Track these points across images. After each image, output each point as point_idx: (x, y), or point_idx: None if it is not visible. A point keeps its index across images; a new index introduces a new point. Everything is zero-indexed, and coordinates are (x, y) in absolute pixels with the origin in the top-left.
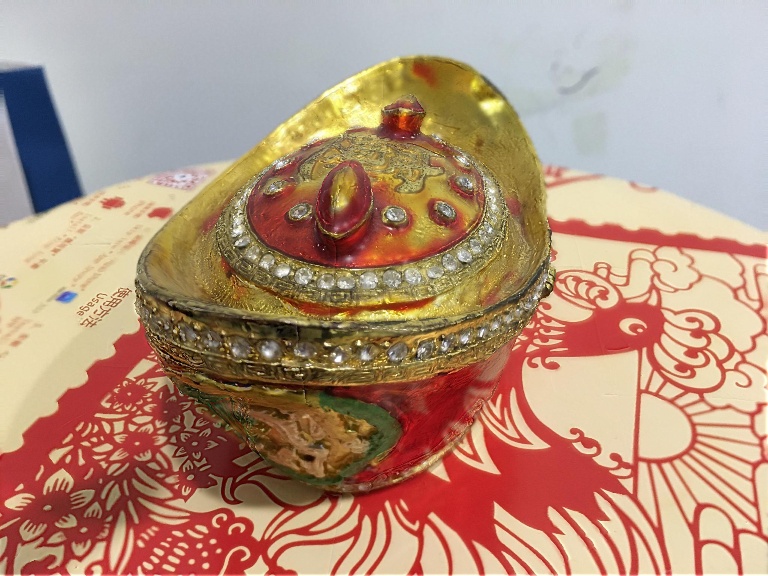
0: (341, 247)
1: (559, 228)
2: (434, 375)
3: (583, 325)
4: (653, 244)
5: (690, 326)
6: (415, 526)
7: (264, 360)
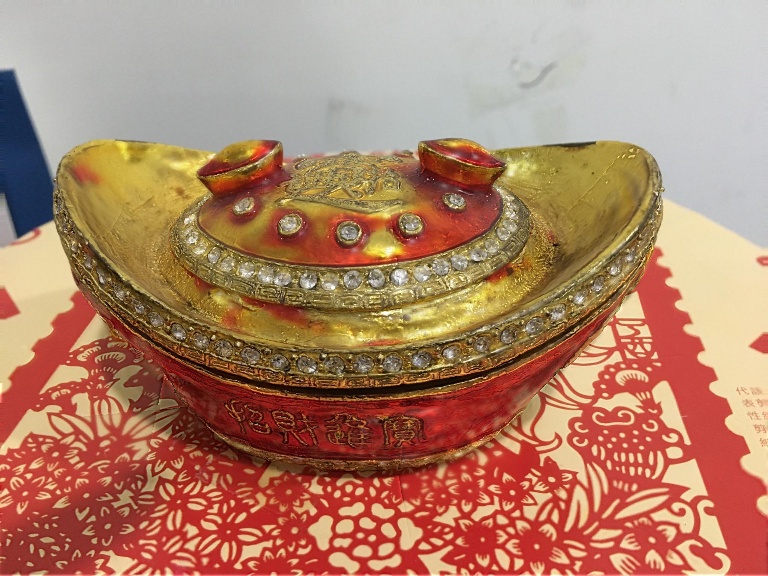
0: None
1: None
2: None
3: None
4: None
5: None
6: None
7: None
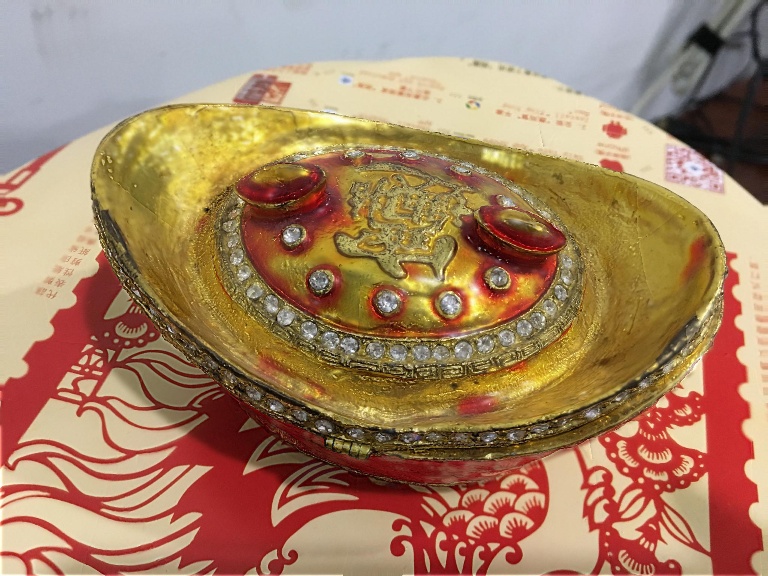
0: None
1: None
2: None
3: None
4: None
5: None
6: (197, 404)
7: None
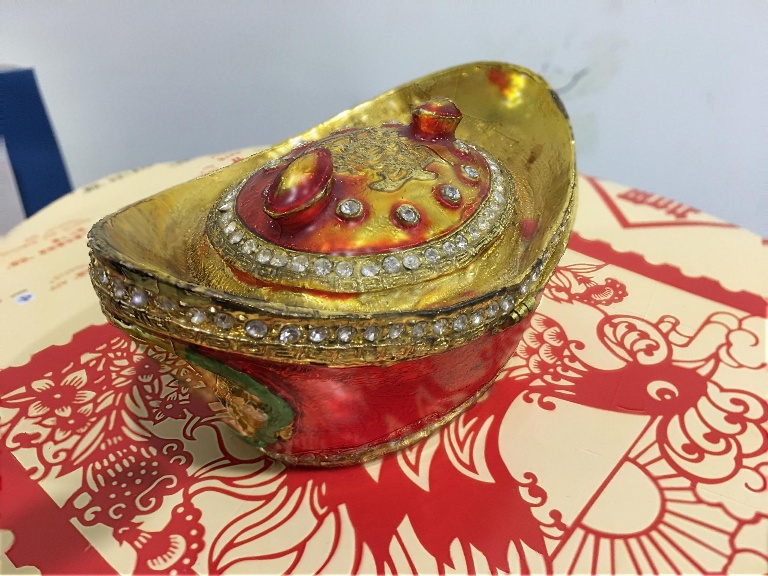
0: (287, 227)
1: (645, 270)
2: (305, 362)
3: (607, 375)
4: (745, 311)
5: (730, 408)
6: (322, 510)
7: (134, 304)
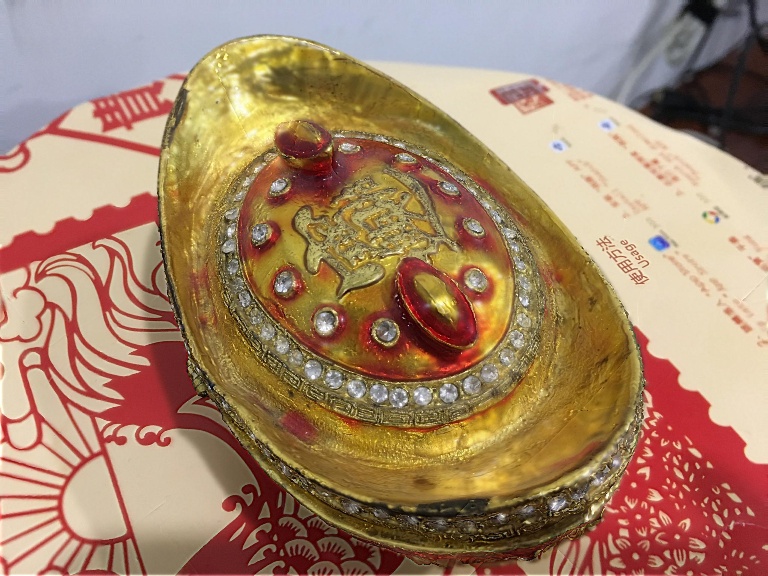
0: None
1: None
2: None
3: None
4: None
5: None
6: None
7: None
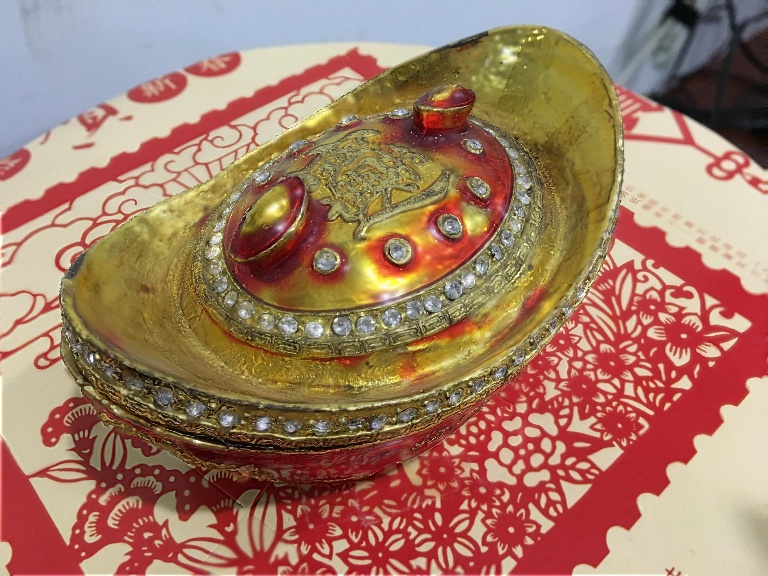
0: None
1: None
2: None
3: None
4: None
5: None
6: None
7: None
